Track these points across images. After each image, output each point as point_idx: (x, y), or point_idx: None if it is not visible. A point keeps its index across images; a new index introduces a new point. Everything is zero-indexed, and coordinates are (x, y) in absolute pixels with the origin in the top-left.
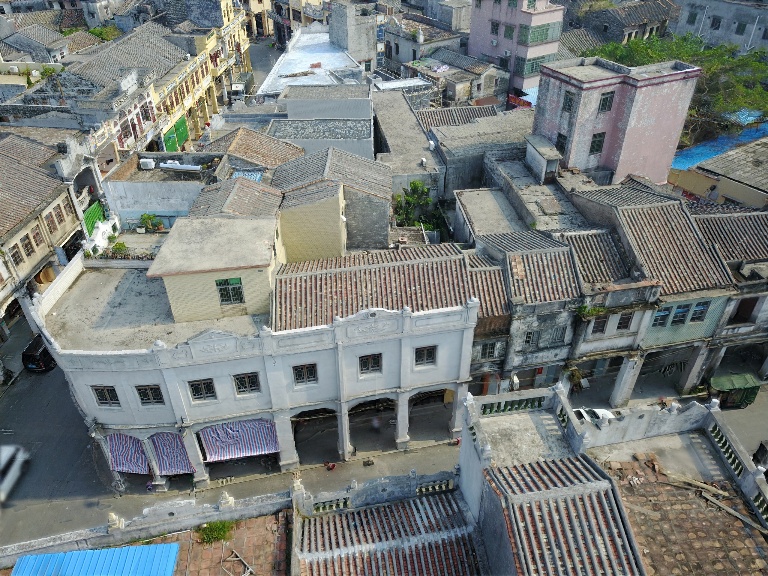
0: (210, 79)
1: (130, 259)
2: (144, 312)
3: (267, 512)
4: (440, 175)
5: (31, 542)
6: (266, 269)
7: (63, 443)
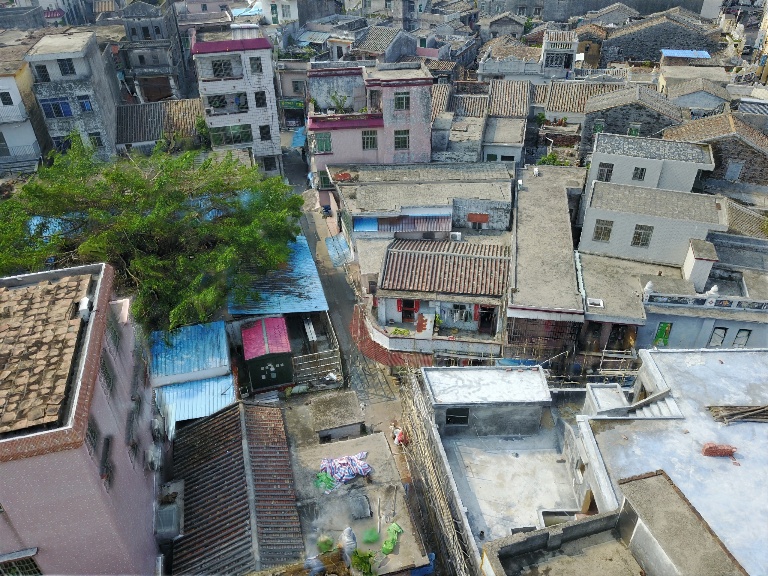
0: None
1: None
2: None
3: None
4: None
5: None
6: None
7: None
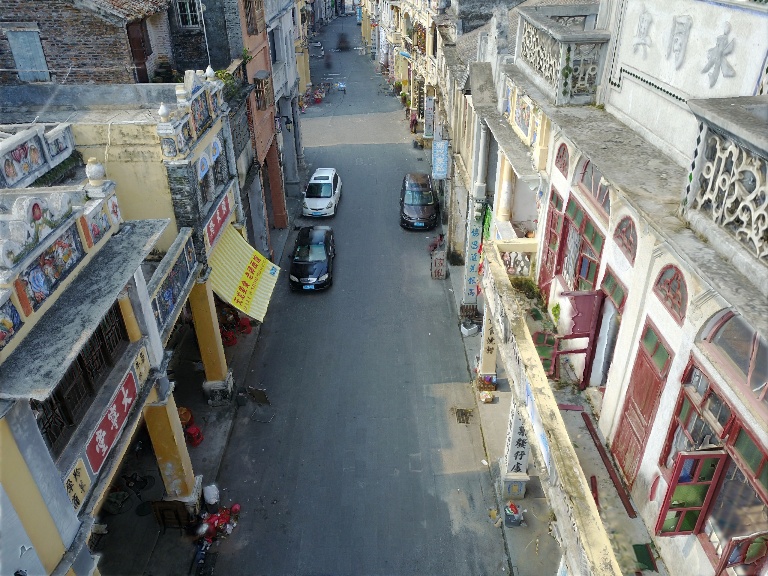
0: None
1: None
2: None
3: None
4: None
5: None
6: None
7: (336, 165)
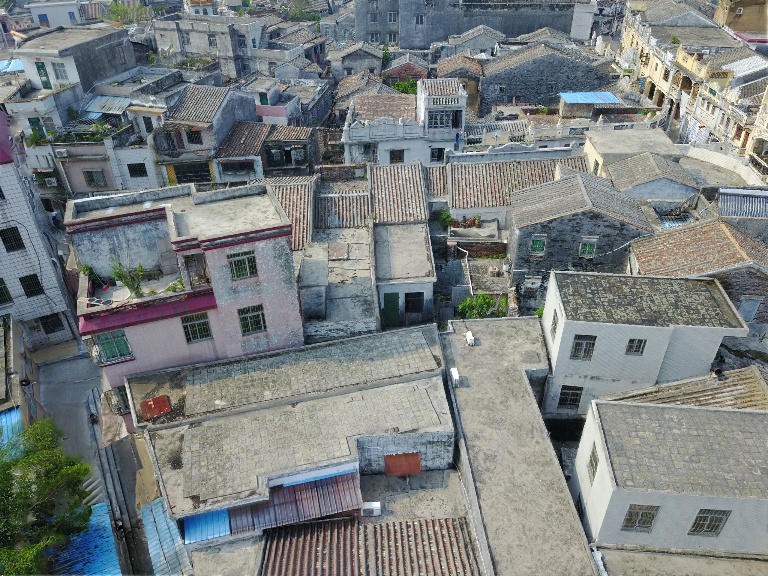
0: None
1: None
2: None
3: None
4: None
5: (630, 123)
6: None
7: None
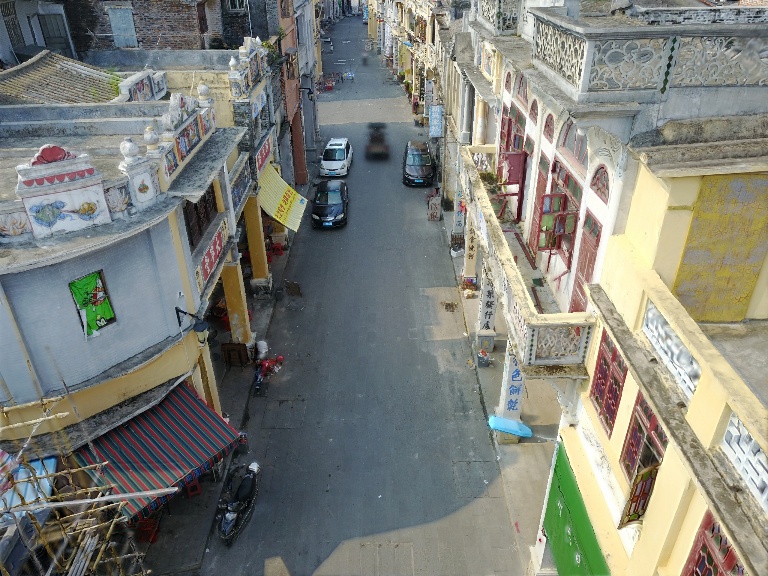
0: None
1: None
2: None
3: None
4: None
5: None
6: None
7: None
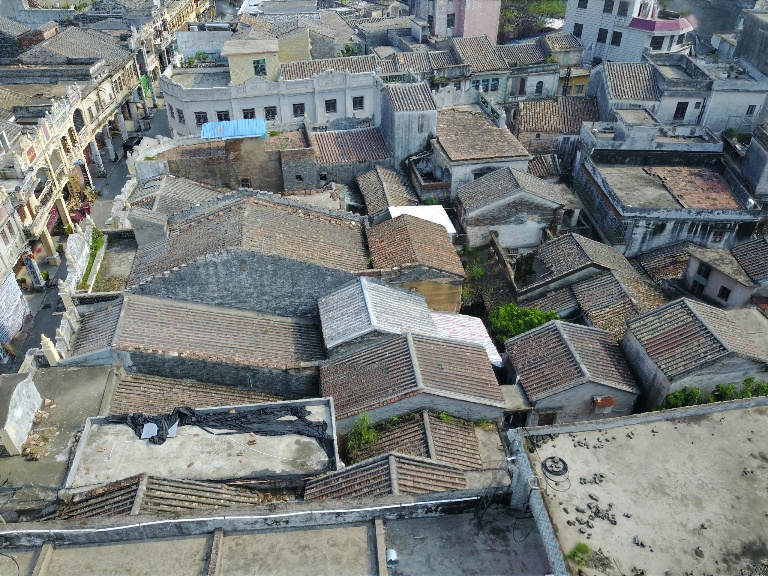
0: (194, 16)
1: (198, 67)
2: (214, 84)
3: (293, 130)
4: (362, 46)
5: (199, 134)
6: (277, 55)
7: None
